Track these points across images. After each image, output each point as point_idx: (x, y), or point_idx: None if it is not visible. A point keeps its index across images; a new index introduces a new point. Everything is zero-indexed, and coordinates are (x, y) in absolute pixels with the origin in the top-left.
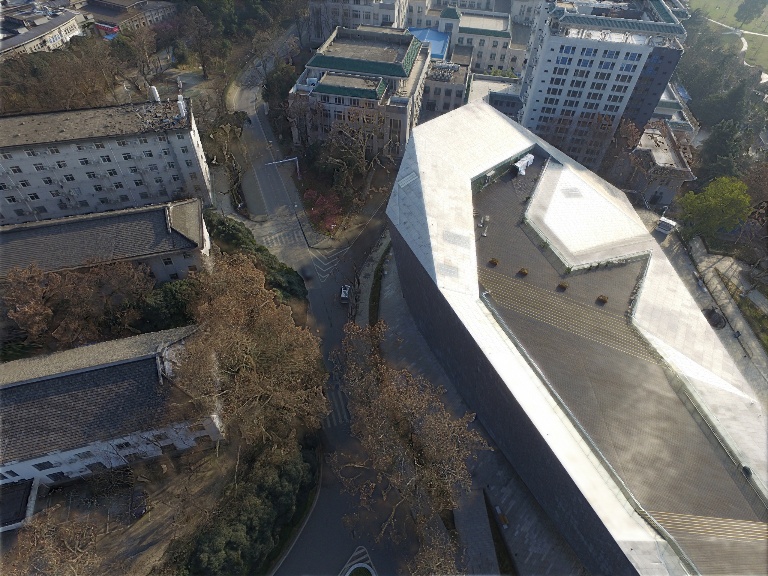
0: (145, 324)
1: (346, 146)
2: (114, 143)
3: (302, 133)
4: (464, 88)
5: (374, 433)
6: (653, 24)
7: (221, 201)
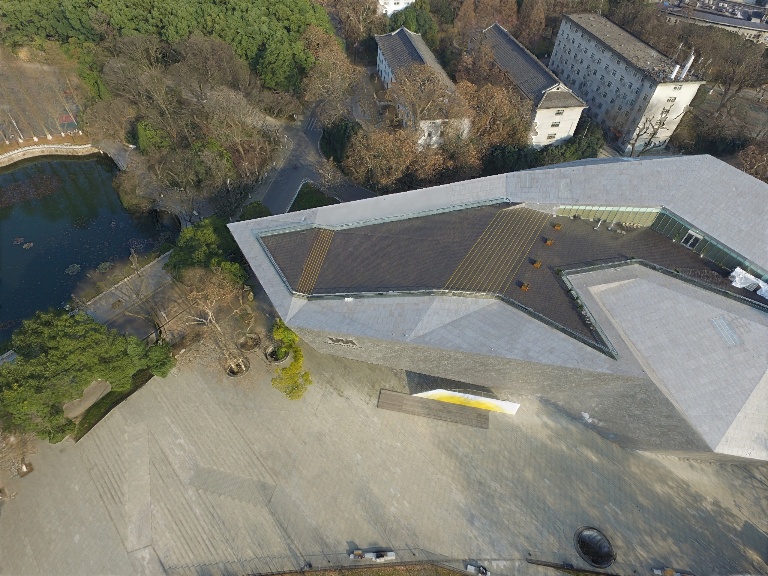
0: None
1: None
2: (624, 65)
3: None
4: None
5: None
6: None
7: None
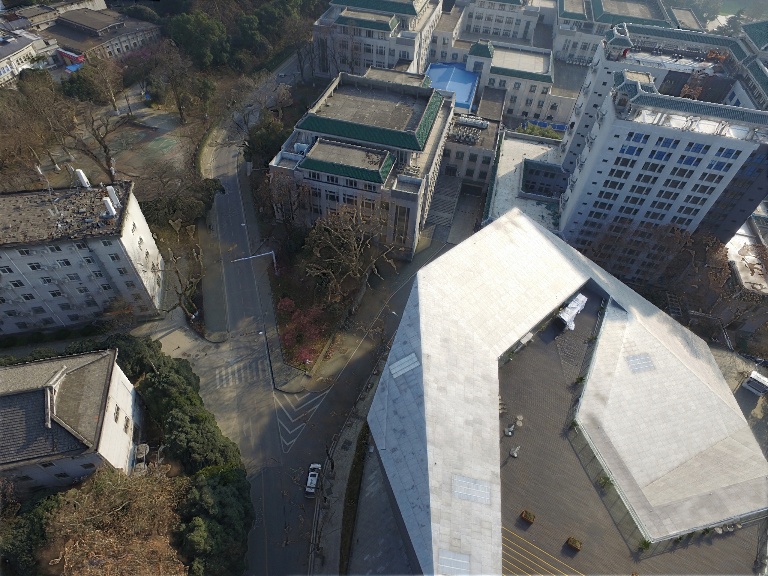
0: (2, 566)
1: (335, 246)
2: (14, 252)
3: (286, 210)
4: (493, 154)
5: None
6: (763, 114)
7: (172, 306)
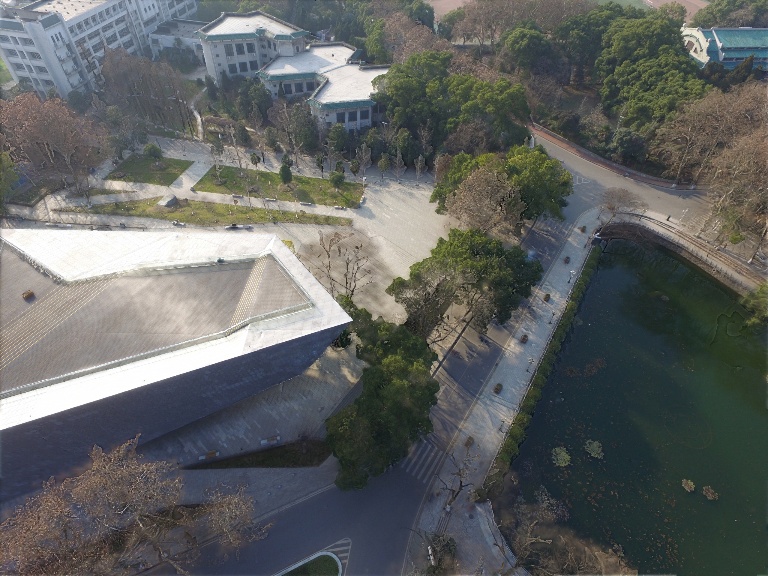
0: None
1: None
2: None
3: None
4: None
5: (66, 570)
6: None
7: None
